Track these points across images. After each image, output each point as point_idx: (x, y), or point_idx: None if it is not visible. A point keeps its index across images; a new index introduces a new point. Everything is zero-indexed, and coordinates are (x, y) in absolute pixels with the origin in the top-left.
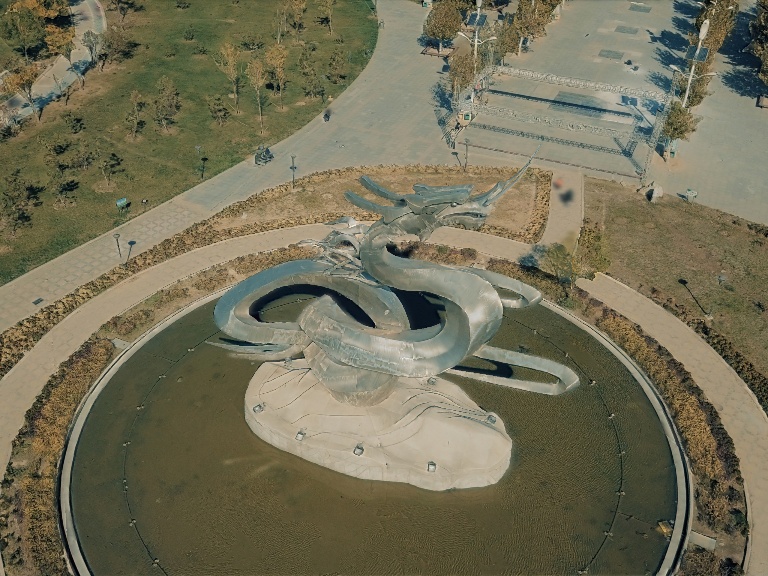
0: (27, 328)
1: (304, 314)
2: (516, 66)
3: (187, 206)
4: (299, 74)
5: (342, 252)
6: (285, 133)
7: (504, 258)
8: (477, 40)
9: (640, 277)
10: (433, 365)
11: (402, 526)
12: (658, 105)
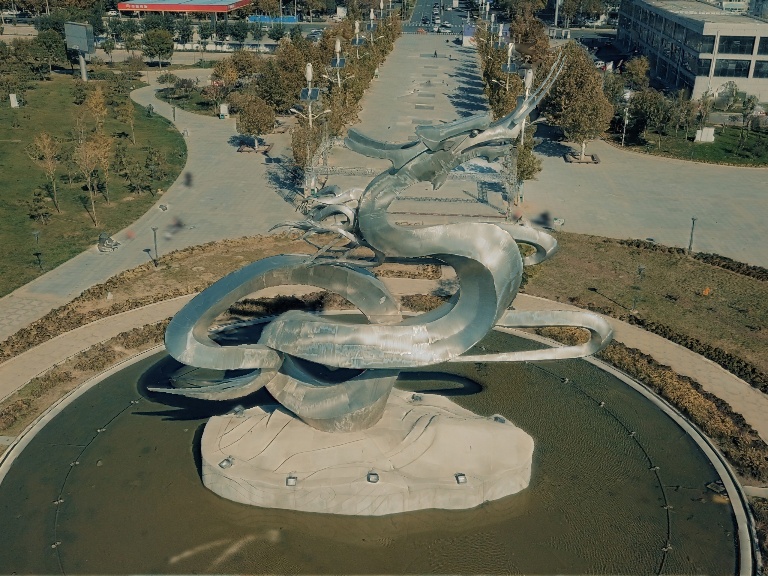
0: None
1: (269, 333)
2: (337, 153)
3: (34, 297)
4: (115, 176)
5: (331, 227)
6: (123, 223)
7: (415, 294)
8: (311, 115)
9: (552, 291)
10: (455, 344)
11: (421, 575)
12: (484, 168)
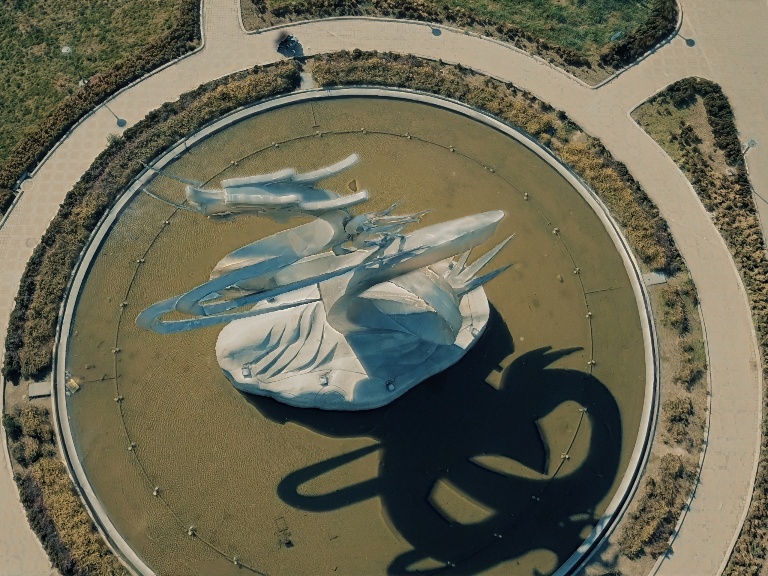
0: (748, 235)
1: None
2: None
3: None
4: None
5: None
6: None
7: None
8: None
9: None
10: None
11: None
12: None
